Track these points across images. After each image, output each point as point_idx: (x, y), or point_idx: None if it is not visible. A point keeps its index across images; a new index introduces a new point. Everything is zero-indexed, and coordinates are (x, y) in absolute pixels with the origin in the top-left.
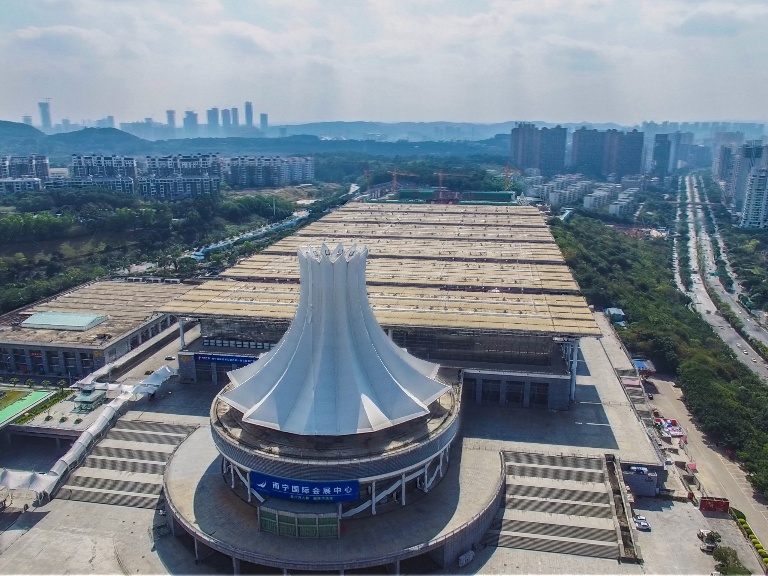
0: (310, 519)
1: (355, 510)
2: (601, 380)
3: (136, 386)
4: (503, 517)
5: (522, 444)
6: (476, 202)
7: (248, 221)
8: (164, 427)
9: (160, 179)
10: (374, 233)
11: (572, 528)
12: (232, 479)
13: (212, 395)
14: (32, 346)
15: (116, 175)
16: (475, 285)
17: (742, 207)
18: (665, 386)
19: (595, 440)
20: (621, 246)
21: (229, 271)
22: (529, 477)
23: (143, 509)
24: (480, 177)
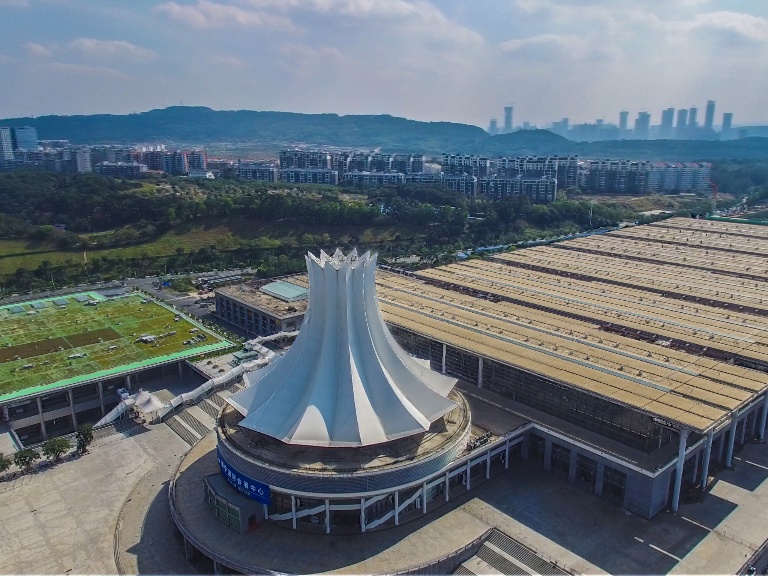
0: (224, 504)
1: (280, 516)
2: (760, 502)
3: (276, 355)
4: None
5: (528, 531)
6: None
7: (557, 227)
8: None
9: (499, 179)
10: (640, 254)
11: None
12: None
13: None
14: (248, 306)
15: (462, 174)
16: (646, 331)
17: None
18: None
19: (628, 567)
20: None
21: (425, 271)
22: (496, 570)
23: None
24: None
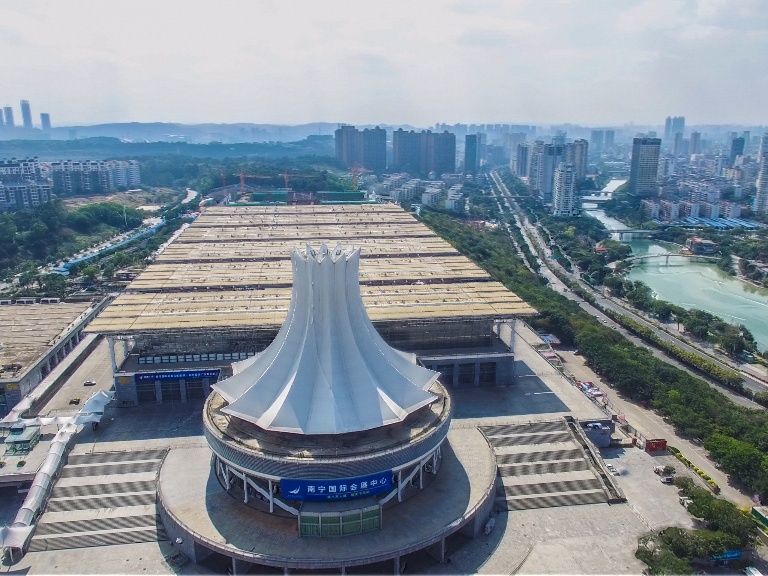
0: (354, 515)
1: (383, 501)
2: (525, 355)
3: (76, 416)
4: (504, 485)
5: (492, 419)
6: (337, 202)
7: (98, 231)
8: (128, 455)
9: None
10: (260, 236)
11: (563, 483)
12: (245, 493)
13: (163, 415)
14: None
15: None
16: (398, 279)
17: (553, 199)
18: (568, 355)
19: (549, 406)
20: (473, 237)
21: (135, 284)
22: (510, 446)
23: (143, 544)
24: (327, 177)
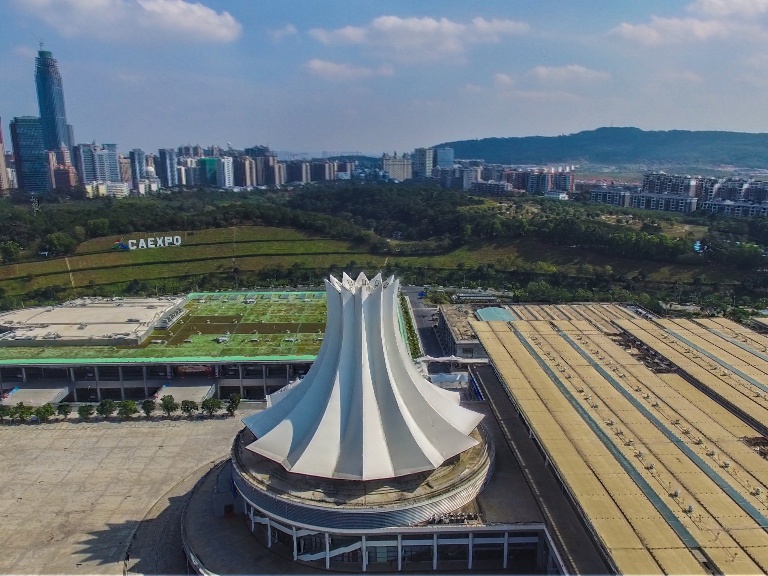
0: None
1: None
2: None
3: (424, 376)
4: None
5: None
6: None
7: None
8: None
9: None
10: None
11: None
12: None
13: None
14: None
15: None
16: None
17: None
18: None
19: None
20: None
21: (633, 320)
22: None
23: None
24: None
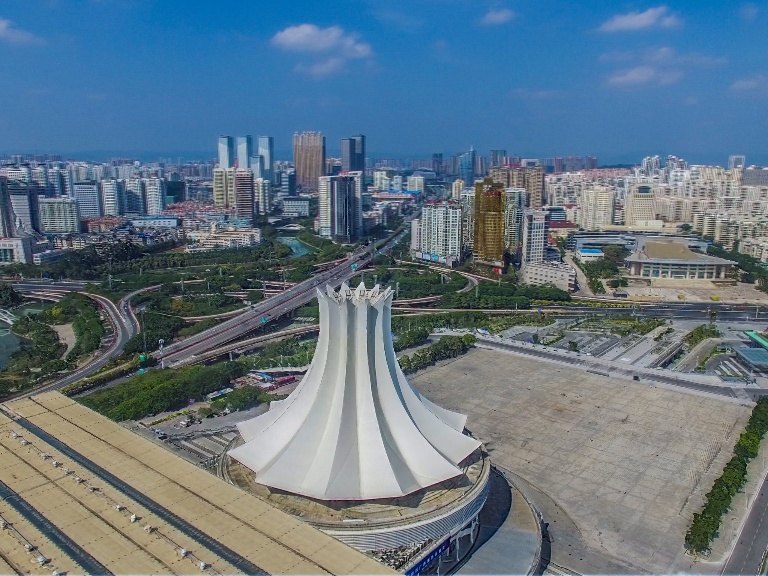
0: None
1: None
2: None
3: None
4: None
5: None
6: None
7: None
8: None
9: None
10: None
11: None
12: None
13: None
14: None
15: None
16: None
17: None
18: None
19: None
20: None
21: None
22: None
23: (565, 567)
24: None
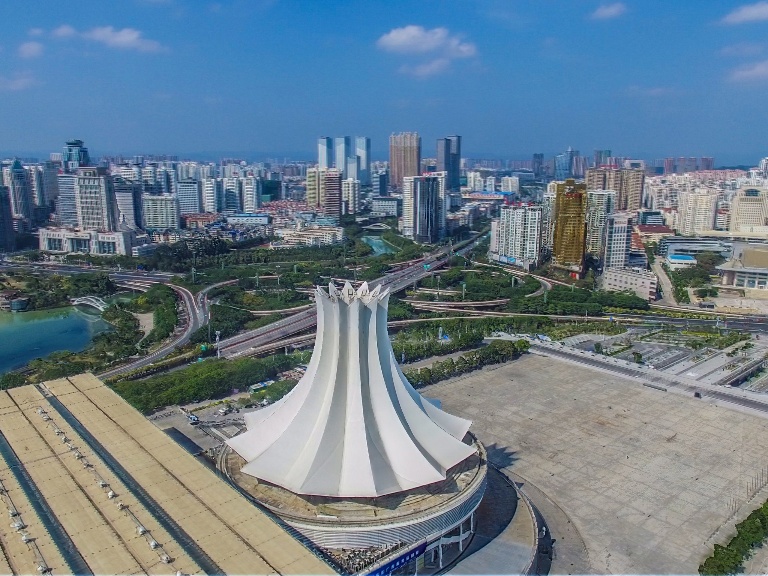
0: None
1: None
2: None
3: None
4: None
5: None
6: None
7: None
8: None
9: None
10: None
11: None
12: None
13: None
14: None
15: None
16: None
17: None
18: None
19: None
20: None
21: None
22: None
23: None
24: None
